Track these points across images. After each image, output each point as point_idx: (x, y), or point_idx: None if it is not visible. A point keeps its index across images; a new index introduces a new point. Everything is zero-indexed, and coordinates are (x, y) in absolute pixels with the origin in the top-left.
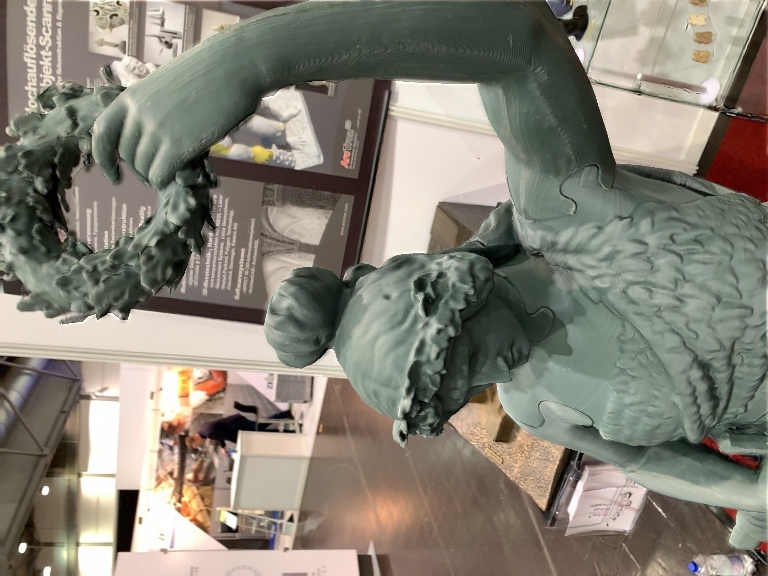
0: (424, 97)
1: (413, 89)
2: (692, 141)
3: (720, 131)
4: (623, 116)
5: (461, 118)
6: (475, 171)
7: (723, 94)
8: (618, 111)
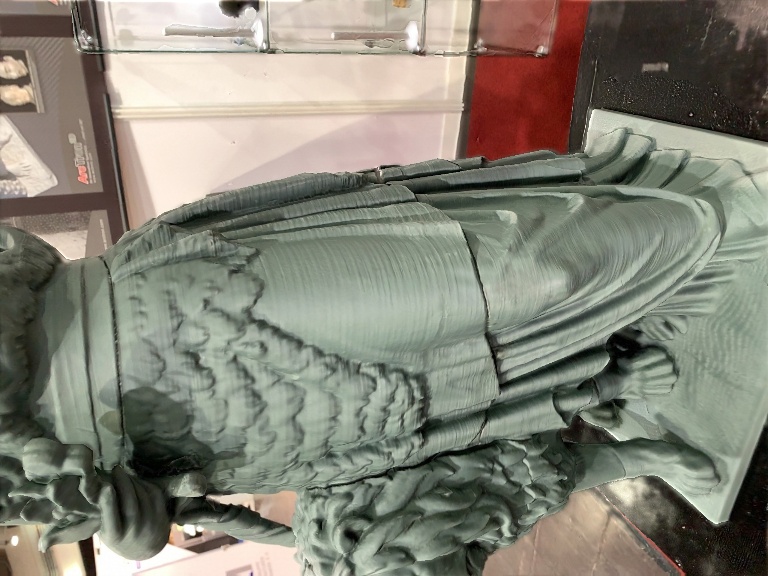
0: (151, 92)
1: (135, 87)
2: (449, 80)
3: (472, 65)
4: (371, 69)
5: (201, 105)
6: (235, 156)
7: (422, 38)
8: (364, 65)
